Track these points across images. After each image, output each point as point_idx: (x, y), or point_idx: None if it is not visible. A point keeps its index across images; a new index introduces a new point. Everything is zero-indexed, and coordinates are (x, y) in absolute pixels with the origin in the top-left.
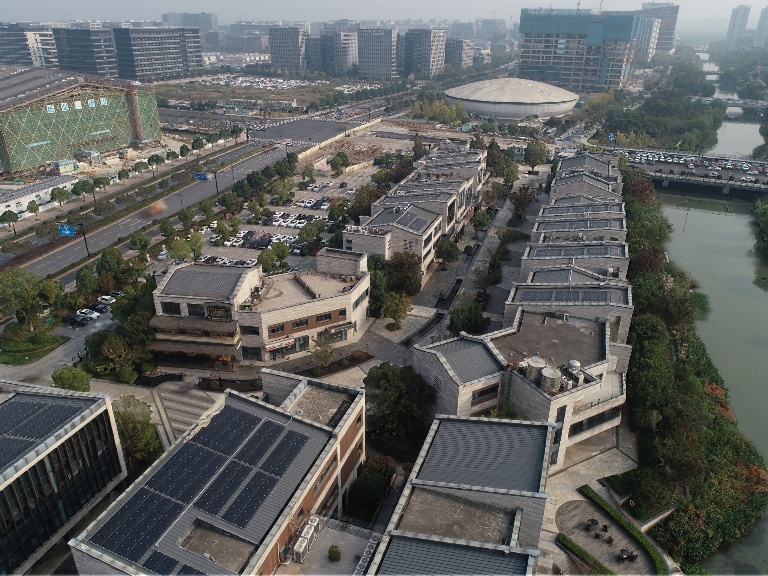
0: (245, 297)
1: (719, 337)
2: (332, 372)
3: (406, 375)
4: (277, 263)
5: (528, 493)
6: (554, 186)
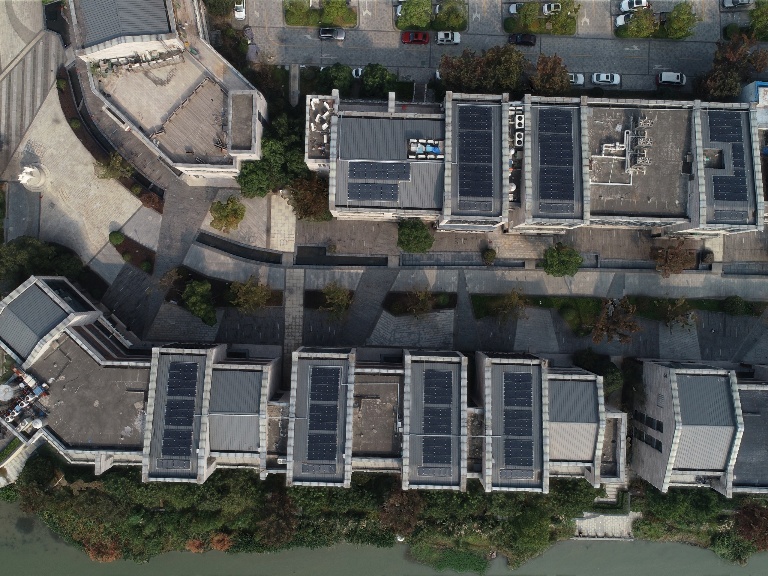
0: (118, 55)
1: (385, 568)
2: (122, 183)
3: (7, 278)
4: (360, 0)
5: None
6: (670, 374)
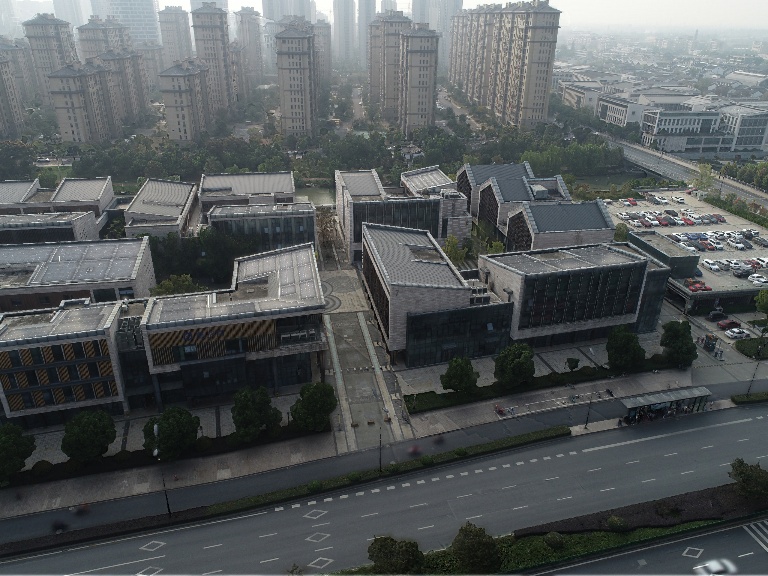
0: None
1: None
2: None
3: None
4: None
5: (35, 181)
6: None
